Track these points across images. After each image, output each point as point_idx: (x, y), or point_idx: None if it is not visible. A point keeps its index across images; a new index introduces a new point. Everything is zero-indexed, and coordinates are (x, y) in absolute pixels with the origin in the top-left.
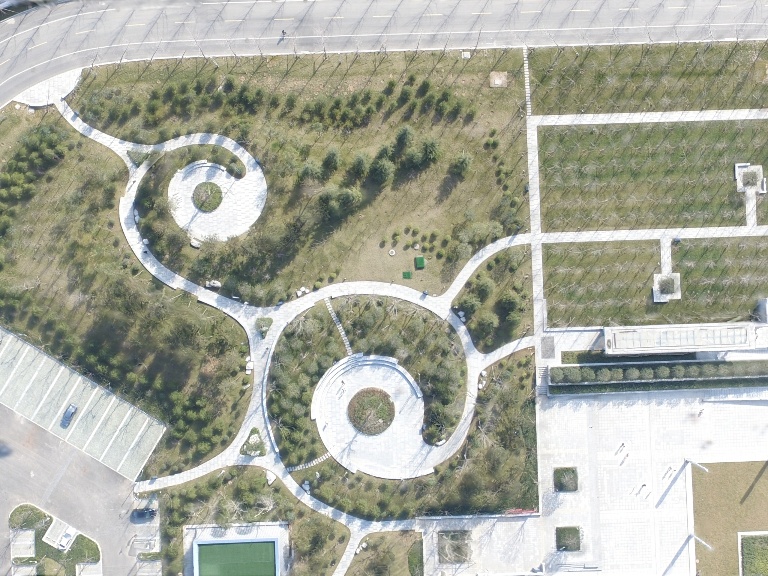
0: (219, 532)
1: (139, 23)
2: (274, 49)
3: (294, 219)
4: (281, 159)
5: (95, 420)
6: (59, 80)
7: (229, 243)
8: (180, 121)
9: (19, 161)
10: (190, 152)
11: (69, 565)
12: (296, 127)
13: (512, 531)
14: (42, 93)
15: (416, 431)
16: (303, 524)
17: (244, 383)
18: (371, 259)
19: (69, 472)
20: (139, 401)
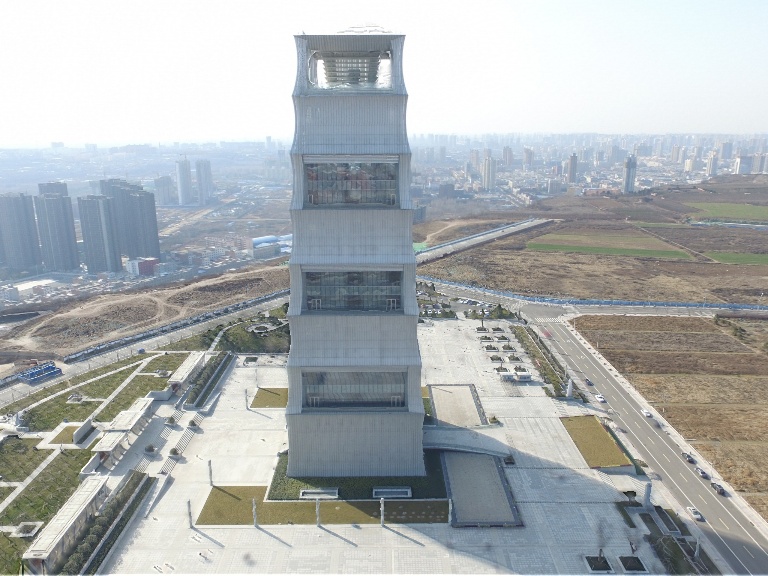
0: None
1: None
2: None
3: None
4: None
5: None
6: None
7: None
8: None
9: None
10: None
11: None
12: None
13: None
14: None
15: None
16: None
17: None
18: None
19: None
20: None
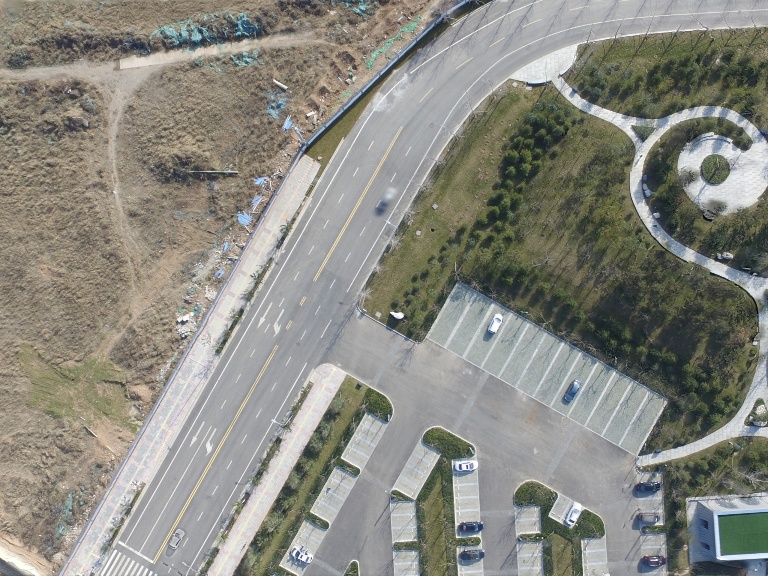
0: (726, 503)
1: None
2: (767, 21)
3: None
4: None
5: (596, 395)
6: (556, 57)
7: (740, 215)
8: (680, 95)
9: (527, 138)
10: (699, 125)
11: (576, 540)
12: None
13: None
14: (539, 70)
15: None
16: None
17: (753, 354)
18: None
19: (572, 448)
20: (642, 375)
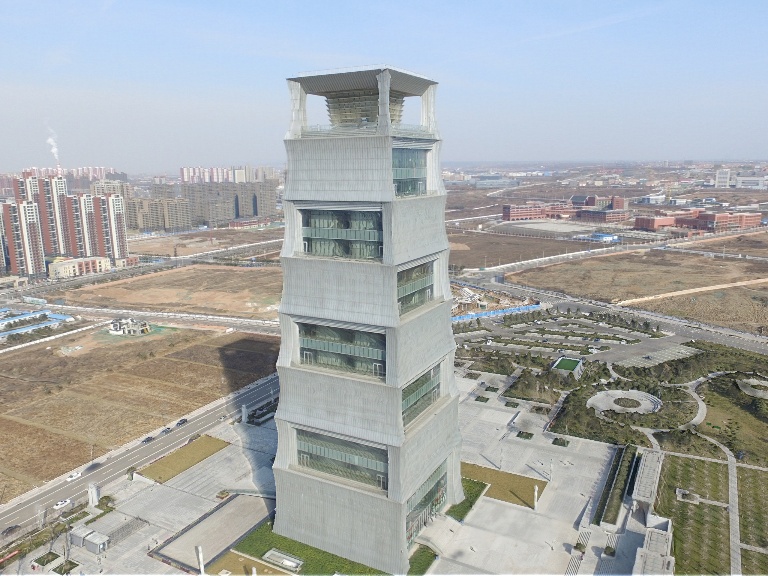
0: None
1: None
2: None
3: None
4: None
5: None
6: None
7: None
8: None
9: None
10: None
11: None
12: None
13: (540, 424)
14: None
15: None
16: None
17: None
18: None
19: None
20: None
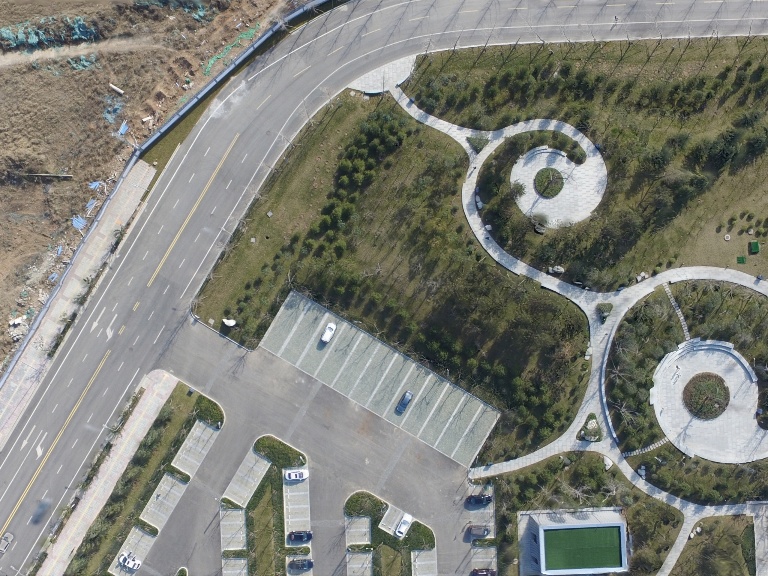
0: (556, 518)
1: (471, 9)
2: (607, 35)
3: (636, 204)
4: (621, 144)
5: (429, 407)
6: (394, 67)
7: (572, 229)
8: (517, 107)
9: (360, 148)
10: (532, 138)
11: (405, 552)
12: (634, 113)
13: None
14: (377, 80)
15: (750, 415)
16: (641, 509)
17: (584, 368)
18: (708, 244)
19: (404, 459)
20: (475, 387)
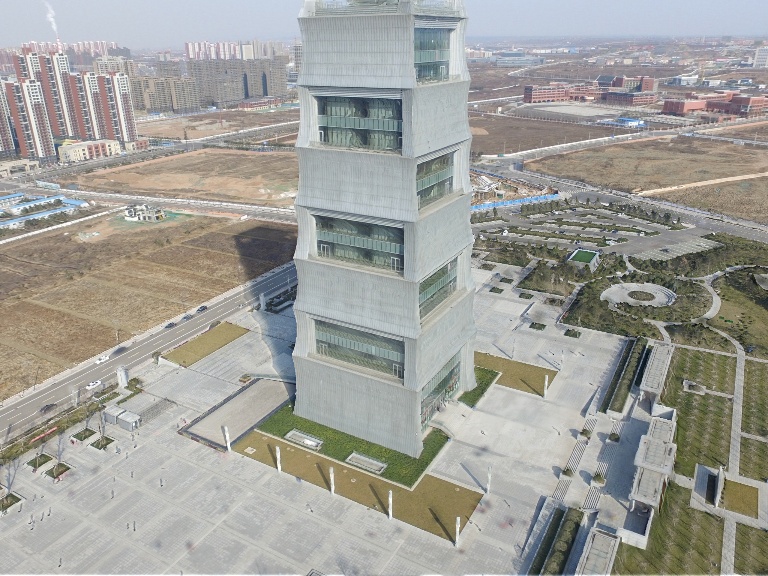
0: None
1: None
2: None
3: (763, 294)
4: None
5: None
6: None
7: None
8: None
9: None
10: None
11: None
12: None
13: None
14: None
15: None
16: None
17: None
18: None
19: None
20: None
